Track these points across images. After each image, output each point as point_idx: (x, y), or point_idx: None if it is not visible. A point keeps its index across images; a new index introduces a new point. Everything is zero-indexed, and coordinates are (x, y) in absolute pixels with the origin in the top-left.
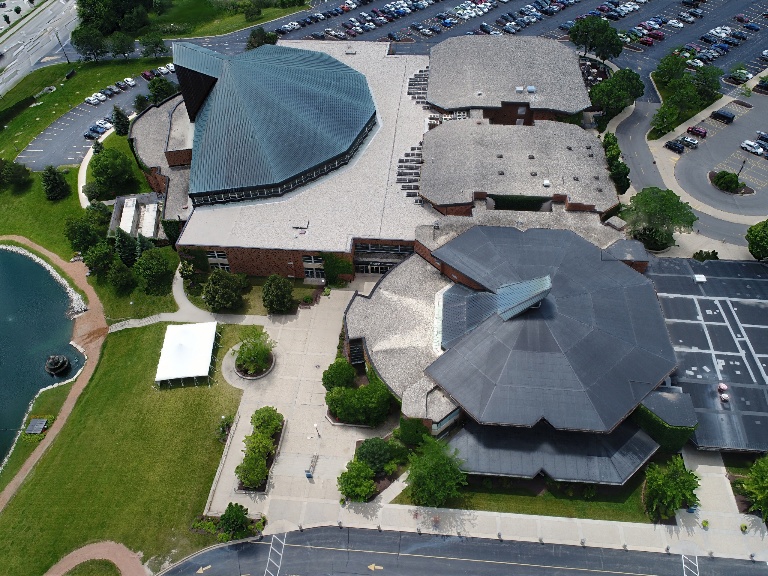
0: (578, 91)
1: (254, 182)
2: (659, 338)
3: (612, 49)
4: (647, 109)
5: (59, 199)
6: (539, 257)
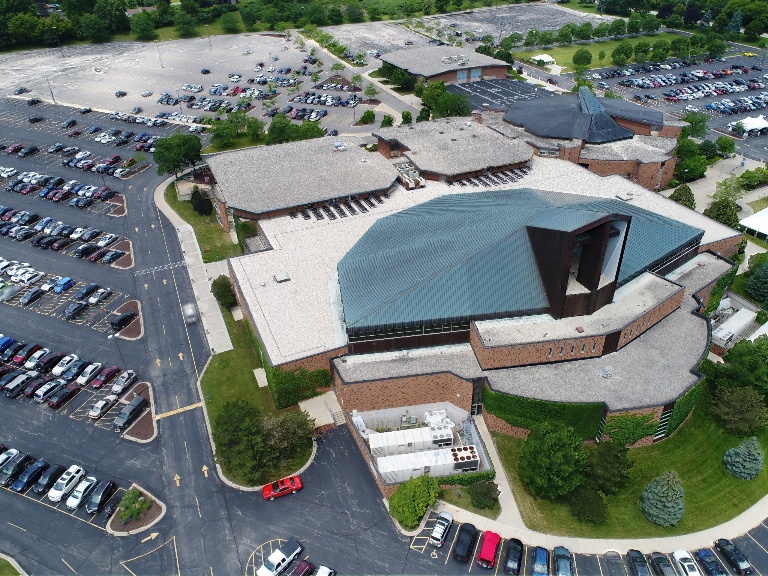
0: (312, 140)
1: (636, 206)
2: (553, 96)
3: None
4: None
5: None
6: (545, 114)
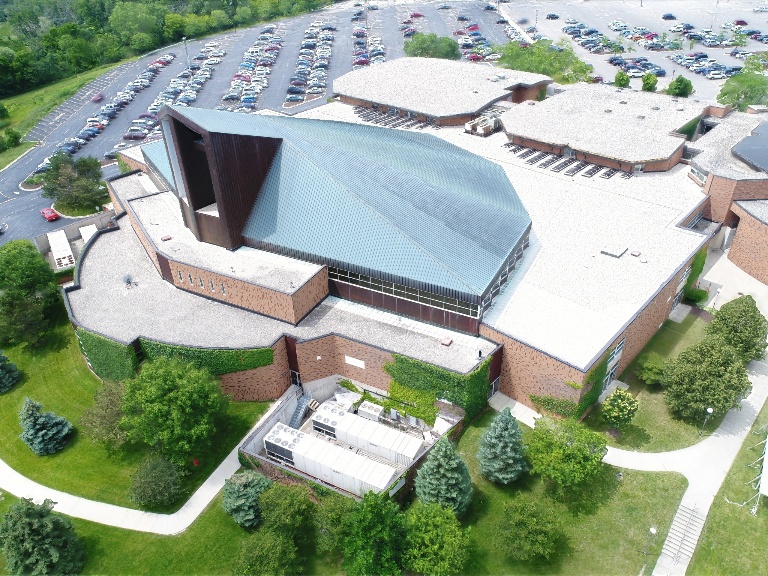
0: None
1: (514, 234)
2: None
3: (455, 55)
4: None
5: (78, 573)
6: None
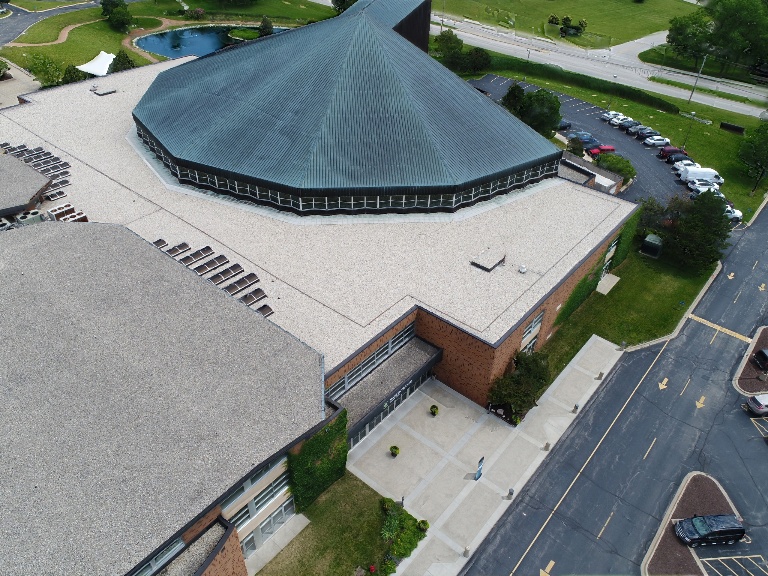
0: None
1: None
2: None
3: None
4: None
5: None
6: None
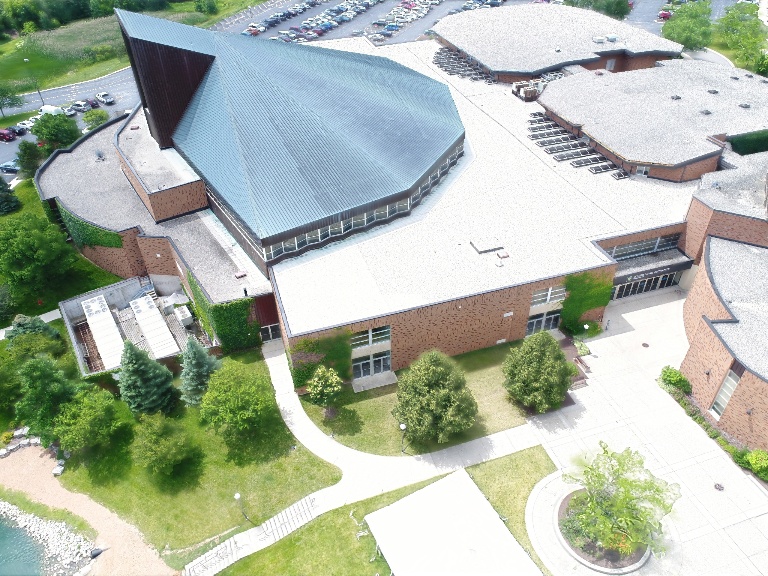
0: (653, 36)
1: (369, 195)
2: None
3: (621, 9)
4: (704, 56)
5: None
6: None
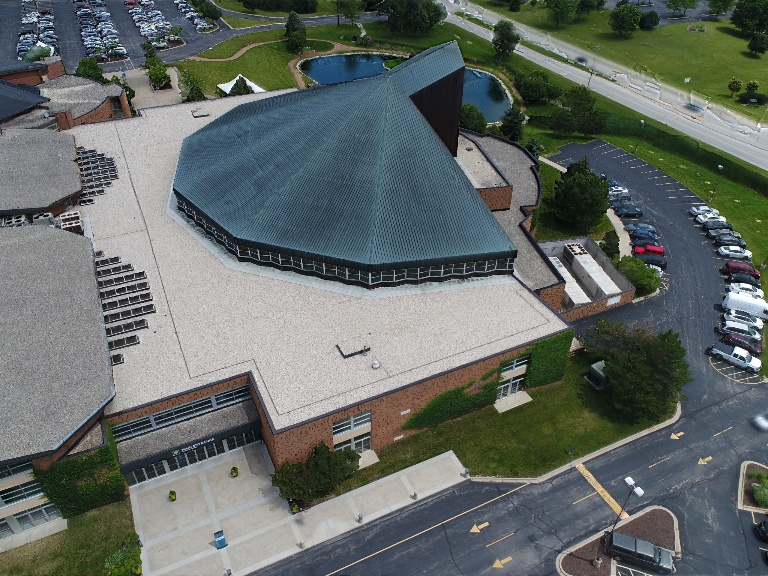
0: None
1: None
2: None
3: None
4: None
5: None
6: None
